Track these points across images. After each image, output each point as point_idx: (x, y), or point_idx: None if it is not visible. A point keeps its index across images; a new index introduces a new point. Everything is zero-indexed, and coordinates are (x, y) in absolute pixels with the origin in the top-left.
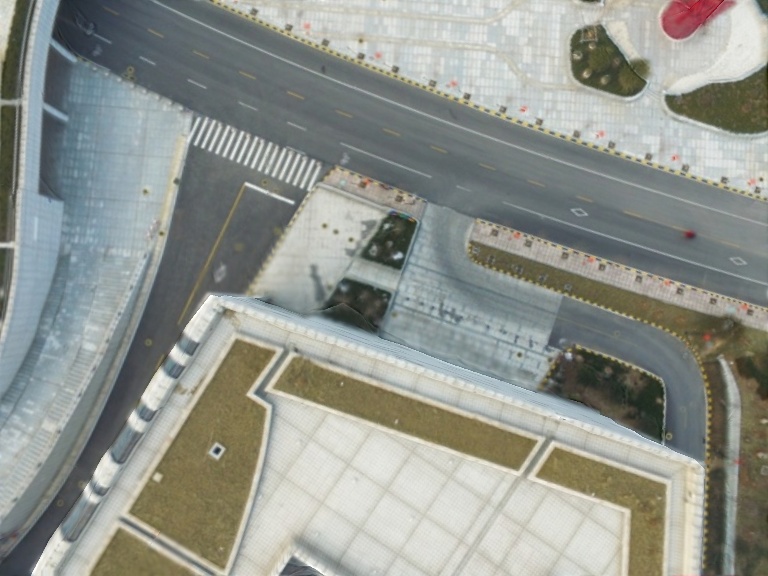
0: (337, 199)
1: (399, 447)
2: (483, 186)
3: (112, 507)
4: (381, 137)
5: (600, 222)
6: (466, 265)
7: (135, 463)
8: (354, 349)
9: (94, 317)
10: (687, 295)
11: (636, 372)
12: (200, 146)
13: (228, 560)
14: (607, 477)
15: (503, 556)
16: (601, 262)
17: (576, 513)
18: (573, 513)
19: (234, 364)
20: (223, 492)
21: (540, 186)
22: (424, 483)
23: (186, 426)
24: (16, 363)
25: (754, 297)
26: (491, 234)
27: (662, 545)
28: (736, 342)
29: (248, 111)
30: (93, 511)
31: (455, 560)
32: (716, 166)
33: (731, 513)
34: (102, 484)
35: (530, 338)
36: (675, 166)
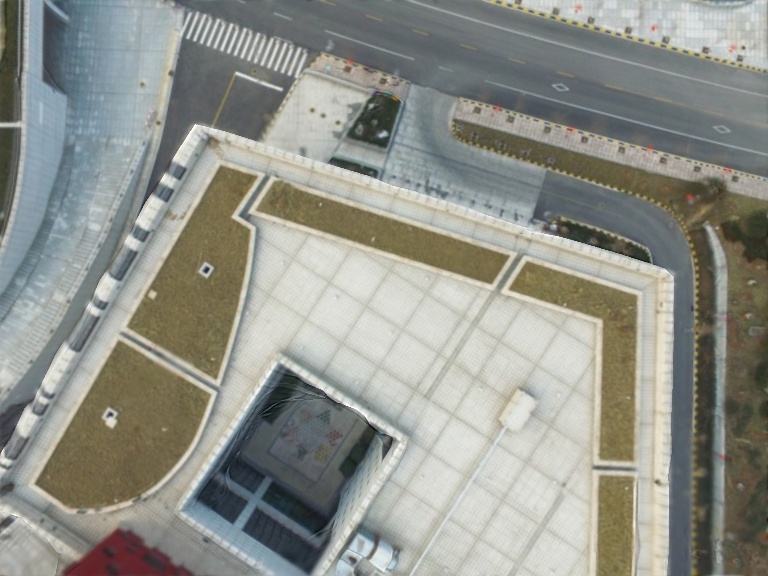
0: (324, 84)
1: (377, 265)
2: (465, 66)
3: (112, 325)
4: (364, 23)
5: (581, 96)
6: (450, 143)
7: (131, 284)
8: (330, 169)
9: (98, 200)
10: (671, 164)
11: (622, 242)
12: (192, 39)
13: (219, 370)
14: (578, 289)
15: (480, 367)
16: (583, 135)
17: (550, 326)
18: (547, 326)
19: (219, 189)
20: (212, 308)
21: (521, 64)
22: (402, 299)
23: (176, 247)
24: (27, 240)
25: (739, 164)
26: (474, 112)
27: (634, 353)
28: (721, 207)
29: (236, 4)
30: (94, 324)
31: (434, 372)
32: (697, 36)
33: (720, 375)
34: (101, 298)
35: (515, 212)
36: (655, 38)
